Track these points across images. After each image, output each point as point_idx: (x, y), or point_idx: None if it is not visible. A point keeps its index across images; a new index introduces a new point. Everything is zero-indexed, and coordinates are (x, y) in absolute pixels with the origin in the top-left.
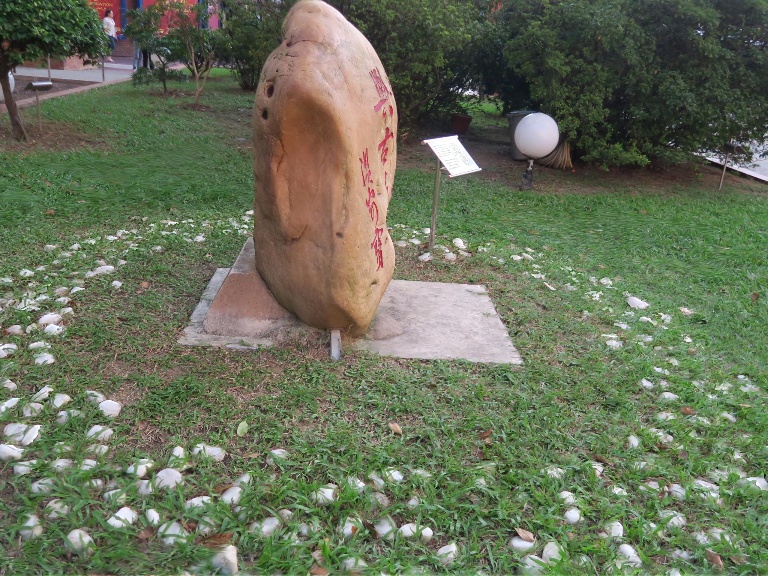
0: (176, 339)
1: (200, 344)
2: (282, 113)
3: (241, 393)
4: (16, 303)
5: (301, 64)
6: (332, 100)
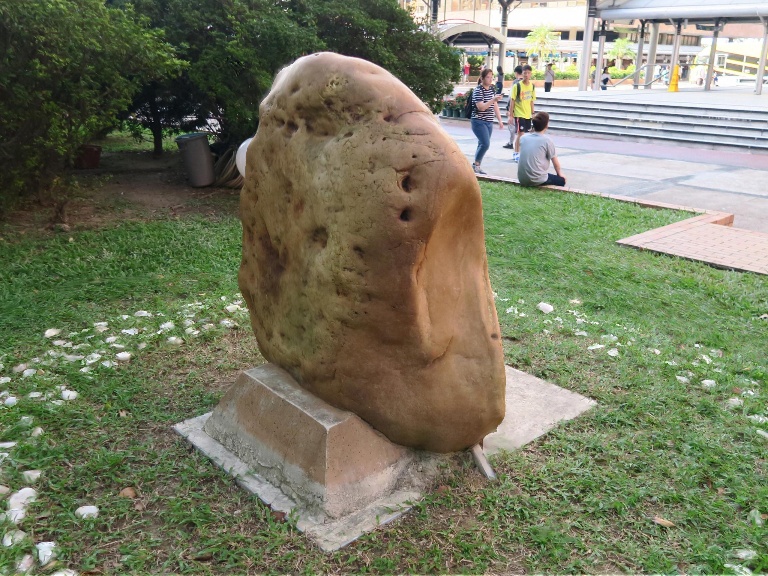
0: (316, 547)
1: (352, 538)
2: (440, 209)
3: (500, 572)
4: None
5: (445, 144)
6: None
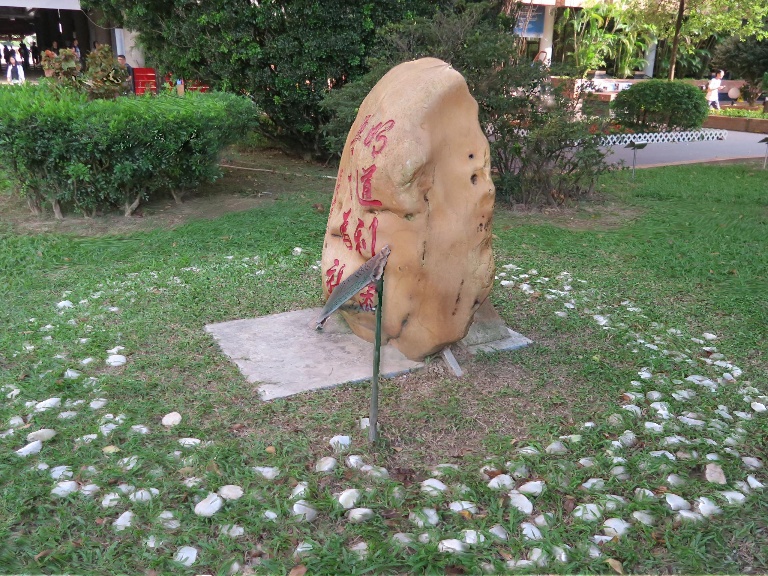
0: None
1: None
2: None
3: None
4: None
5: None
6: None
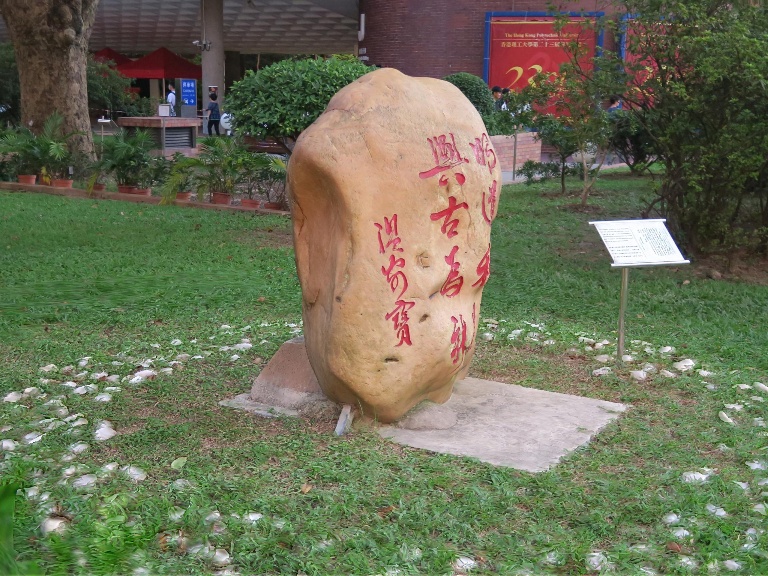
0: (221, 400)
1: (235, 406)
2: (293, 177)
3: (216, 442)
4: (138, 361)
5: (313, 131)
6: (336, 164)
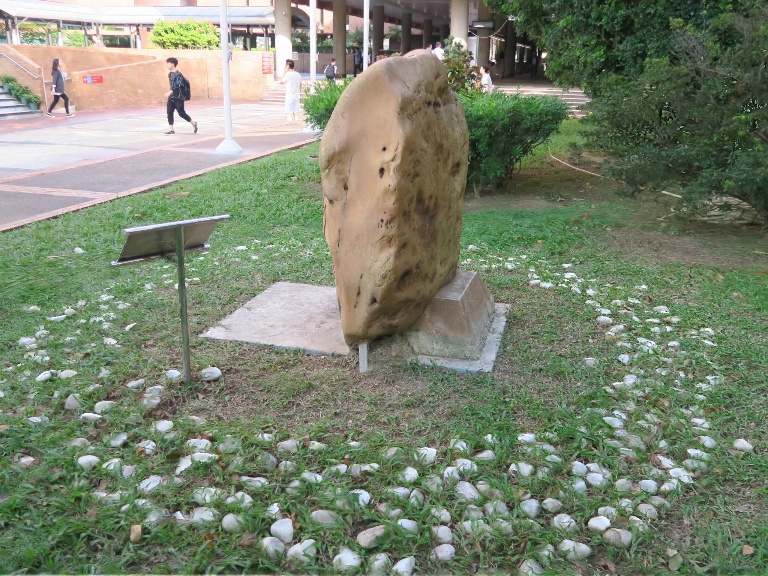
0: None
1: None
2: None
3: None
4: None
5: None
6: None
